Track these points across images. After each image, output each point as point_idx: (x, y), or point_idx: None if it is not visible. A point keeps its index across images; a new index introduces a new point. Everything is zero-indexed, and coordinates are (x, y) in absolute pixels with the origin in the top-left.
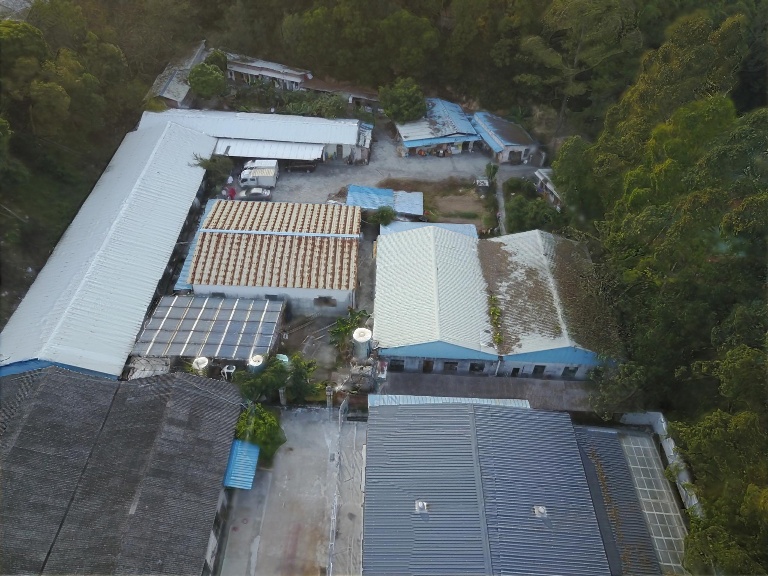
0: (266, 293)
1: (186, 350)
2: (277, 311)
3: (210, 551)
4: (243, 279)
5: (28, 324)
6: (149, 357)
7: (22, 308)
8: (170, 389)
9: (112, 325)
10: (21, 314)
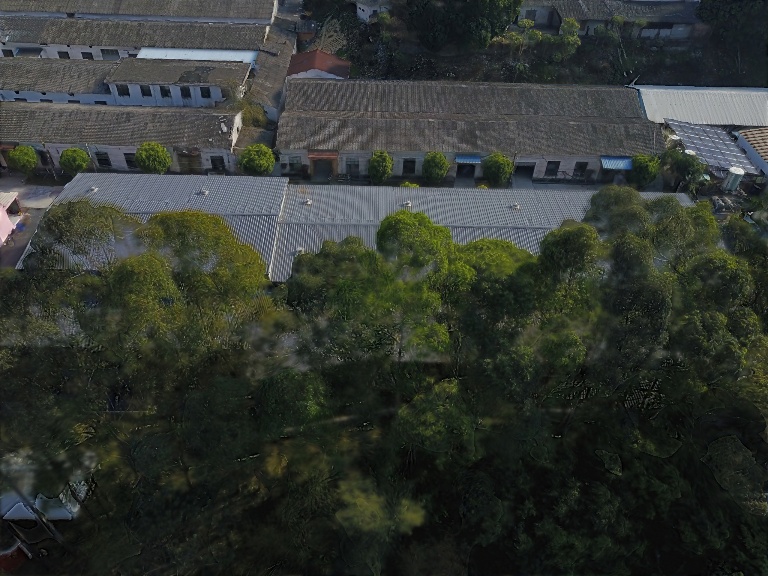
0: (762, 168)
1: (681, 134)
2: (747, 170)
3: (565, 168)
4: (763, 150)
5: (661, 87)
6: (667, 123)
7: (672, 86)
8: (647, 124)
9: (682, 112)
10: (667, 86)
